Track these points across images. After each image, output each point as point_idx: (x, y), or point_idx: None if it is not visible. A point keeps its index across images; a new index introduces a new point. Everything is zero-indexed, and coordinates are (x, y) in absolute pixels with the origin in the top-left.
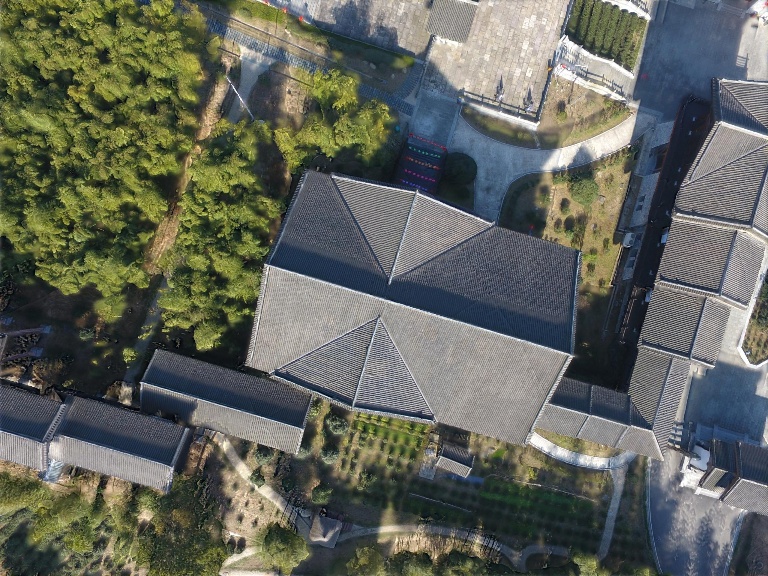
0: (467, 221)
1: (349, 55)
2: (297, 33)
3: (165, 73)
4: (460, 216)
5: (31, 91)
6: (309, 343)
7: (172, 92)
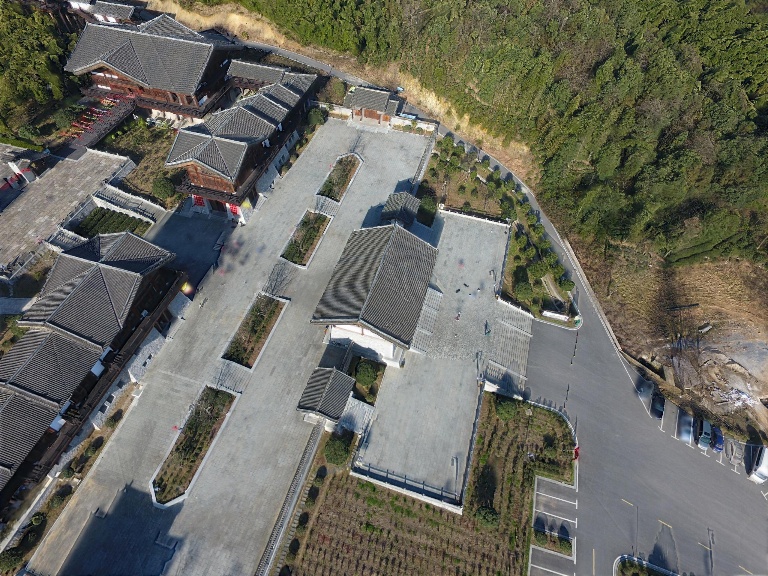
0: None
1: None
2: None
3: None
4: None
5: None
6: None
7: None
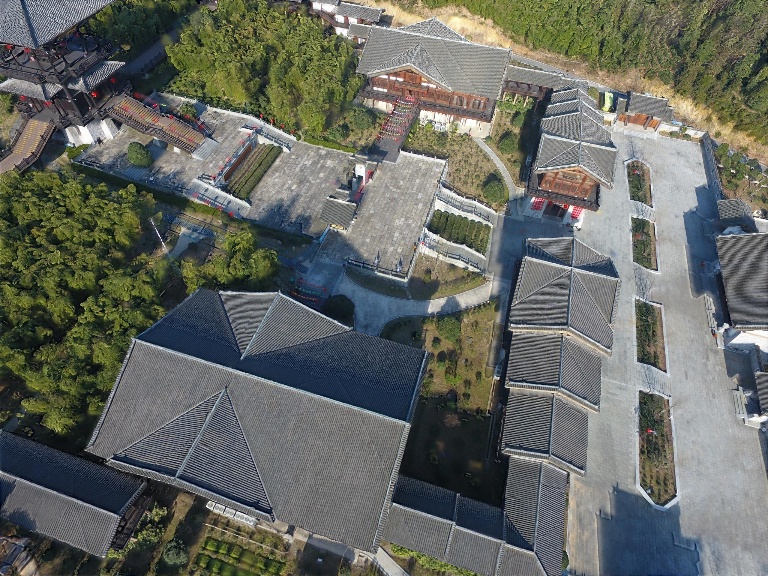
0: (326, 323)
1: (263, 236)
2: (226, 221)
3: (111, 224)
4: (319, 318)
5: (4, 228)
6: (155, 421)
7: (112, 237)
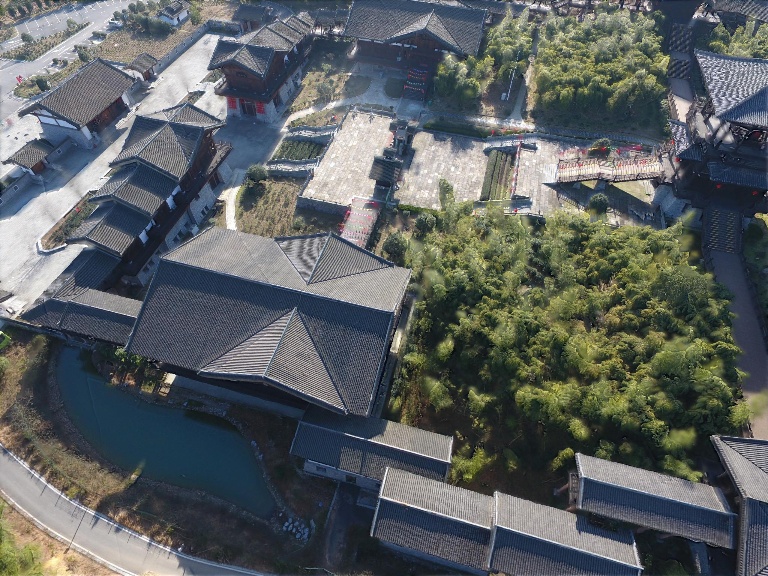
0: None
1: None
2: None
3: None
4: None
5: (610, 55)
6: None
7: None
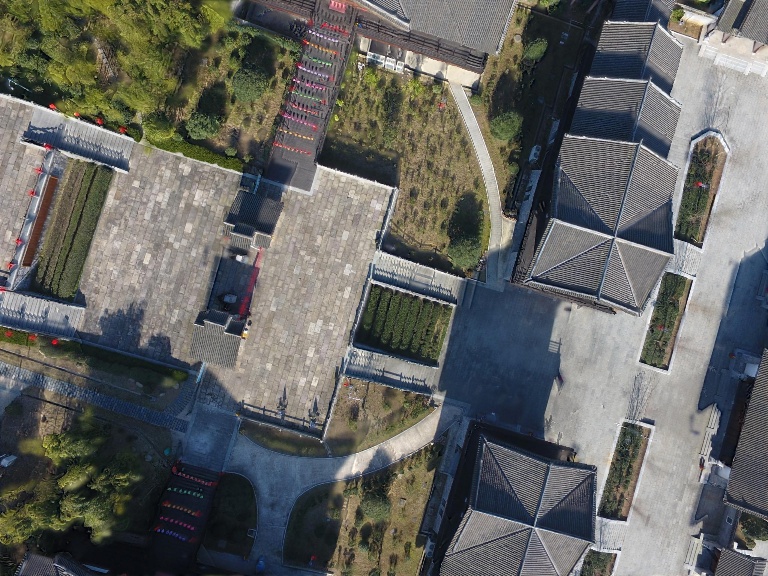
0: None
1: (113, 373)
2: (51, 357)
3: None
4: None
5: None
6: None
7: None
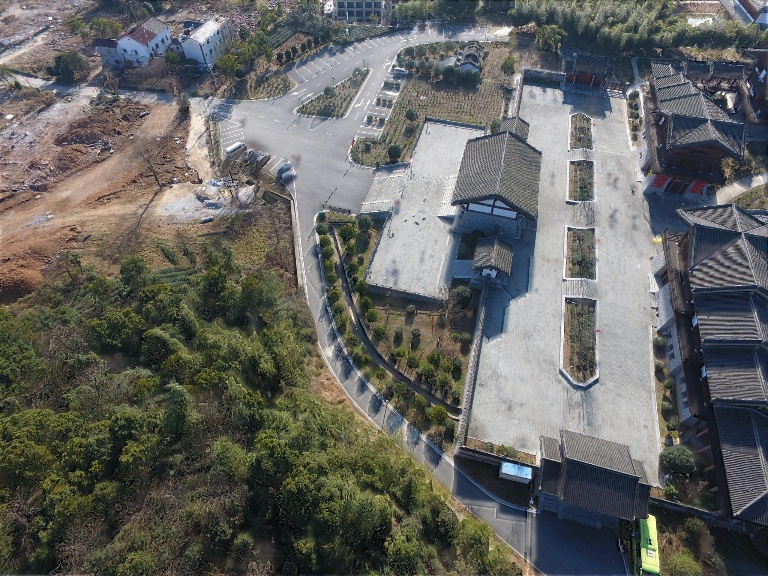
0: None
1: None
2: None
3: None
4: None
5: None
6: None
7: None
